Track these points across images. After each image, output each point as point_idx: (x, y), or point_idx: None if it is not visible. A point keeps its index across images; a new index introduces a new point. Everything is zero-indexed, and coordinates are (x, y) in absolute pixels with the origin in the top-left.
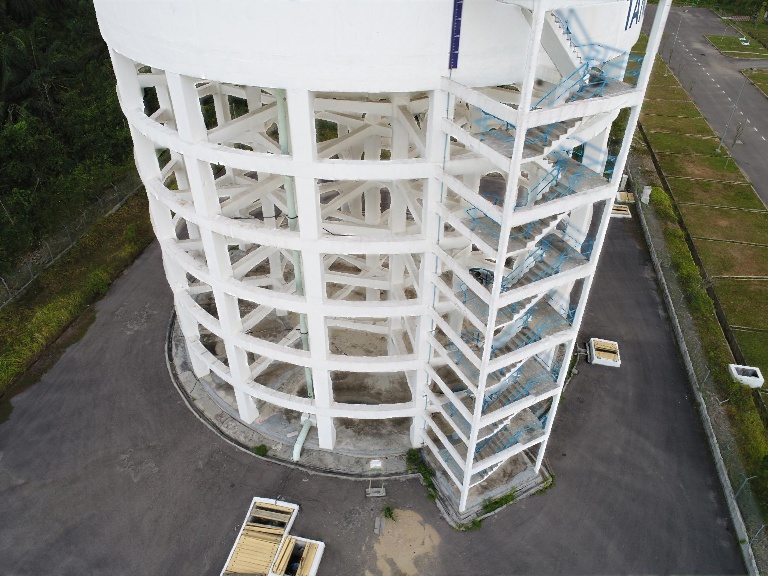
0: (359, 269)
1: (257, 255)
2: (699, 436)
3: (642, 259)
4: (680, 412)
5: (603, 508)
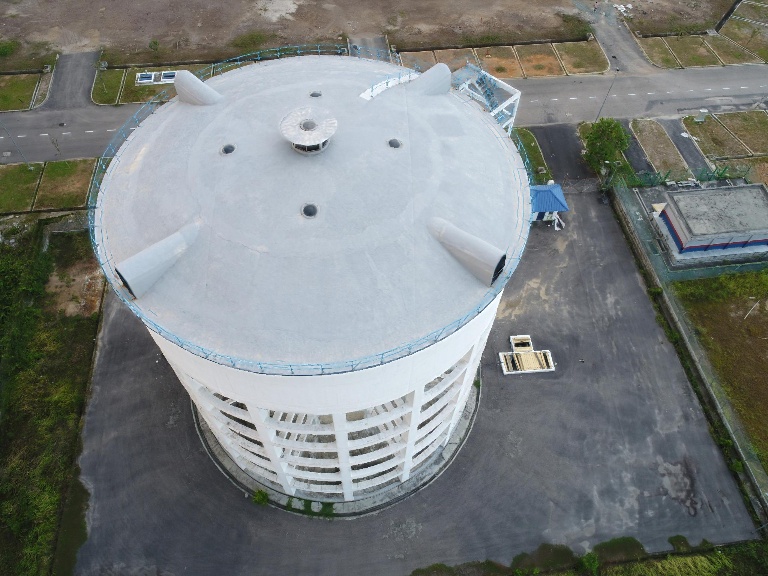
0: None
1: None
2: None
3: None
4: None
5: None
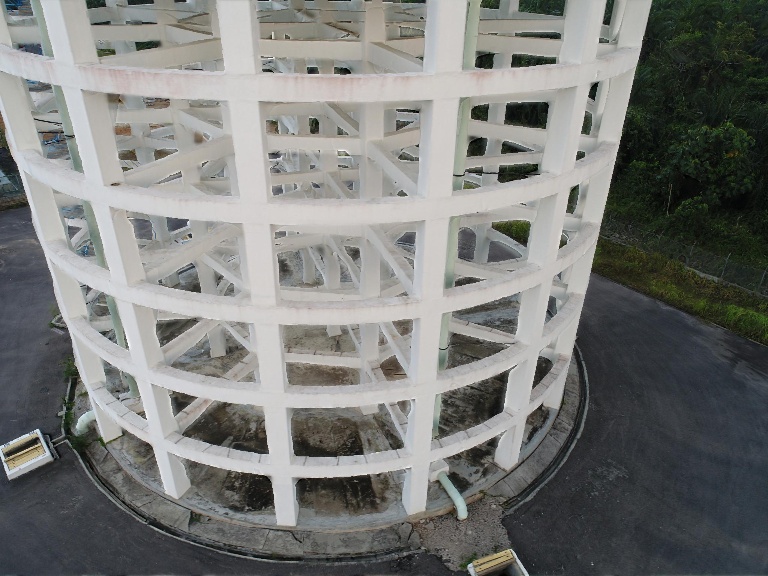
0: None
1: None
2: None
3: None
4: None
5: (2, 333)
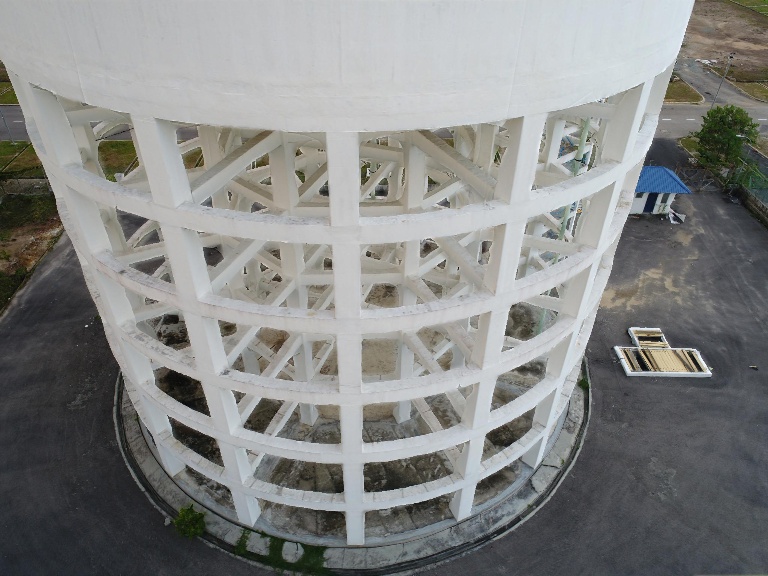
0: None
1: (558, 240)
2: None
3: None
4: None
5: None
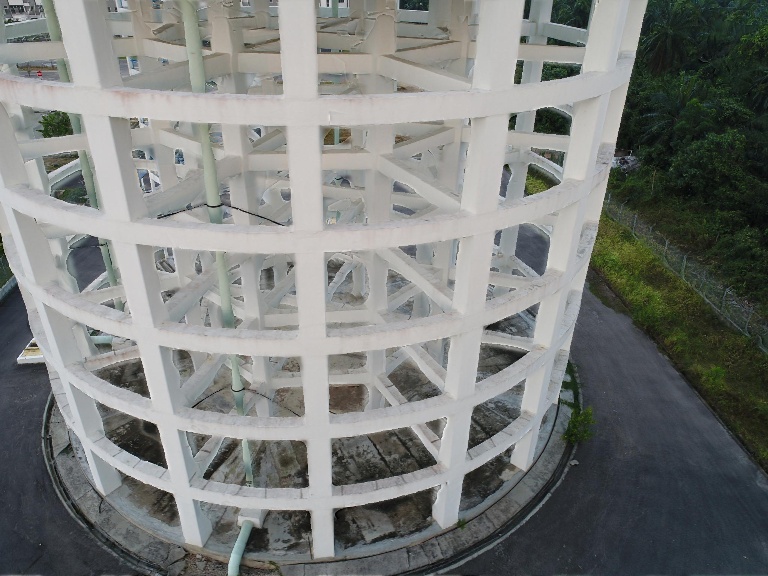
0: (359, 390)
1: None
2: (5, 304)
3: None
4: (4, 317)
5: None
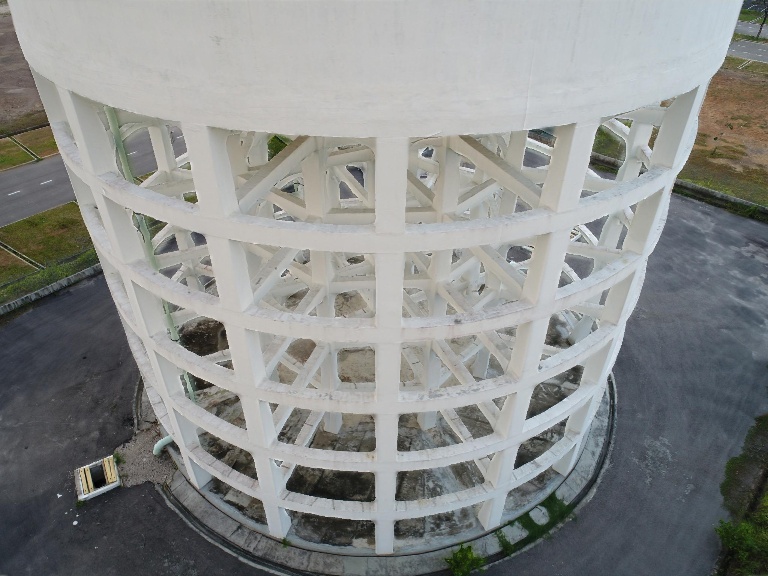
0: None
1: None
2: None
3: (57, 298)
4: None
5: None
